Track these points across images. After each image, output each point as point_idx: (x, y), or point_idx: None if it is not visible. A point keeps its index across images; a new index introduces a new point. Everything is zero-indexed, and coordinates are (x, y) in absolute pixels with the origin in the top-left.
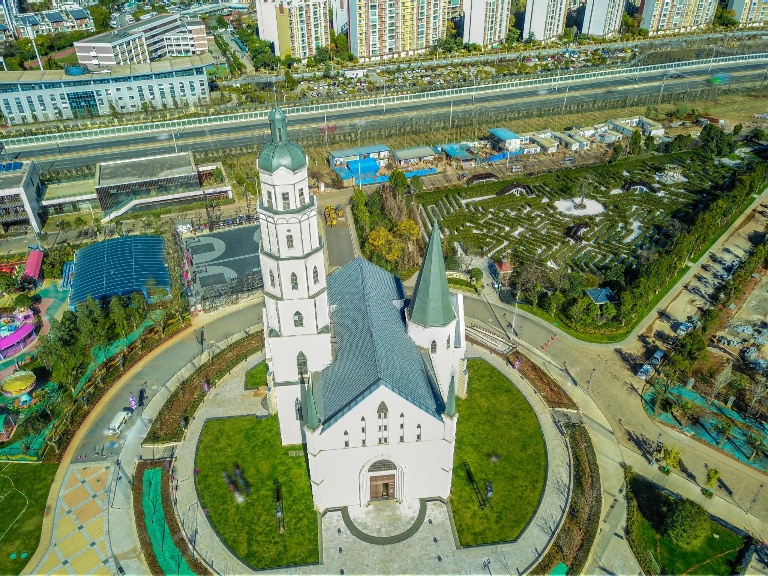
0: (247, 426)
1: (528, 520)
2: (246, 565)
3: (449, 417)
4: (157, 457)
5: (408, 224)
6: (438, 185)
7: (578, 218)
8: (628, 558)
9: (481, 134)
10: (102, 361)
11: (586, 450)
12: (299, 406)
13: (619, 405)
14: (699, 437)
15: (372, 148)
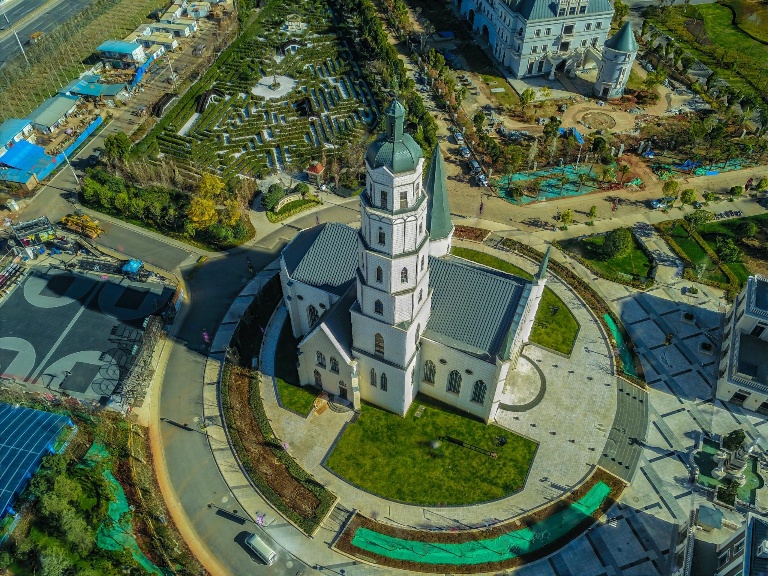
0: (359, 434)
1: (568, 310)
2: (514, 494)
3: (544, 278)
4: (337, 528)
5: (212, 181)
6: (128, 132)
7: (290, 97)
8: (612, 285)
9: (76, 58)
10: (133, 540)
11: (528, 250)
12: (412, 372)
13: (498, 211)
14: (549, 198)
15: (7, 129)
